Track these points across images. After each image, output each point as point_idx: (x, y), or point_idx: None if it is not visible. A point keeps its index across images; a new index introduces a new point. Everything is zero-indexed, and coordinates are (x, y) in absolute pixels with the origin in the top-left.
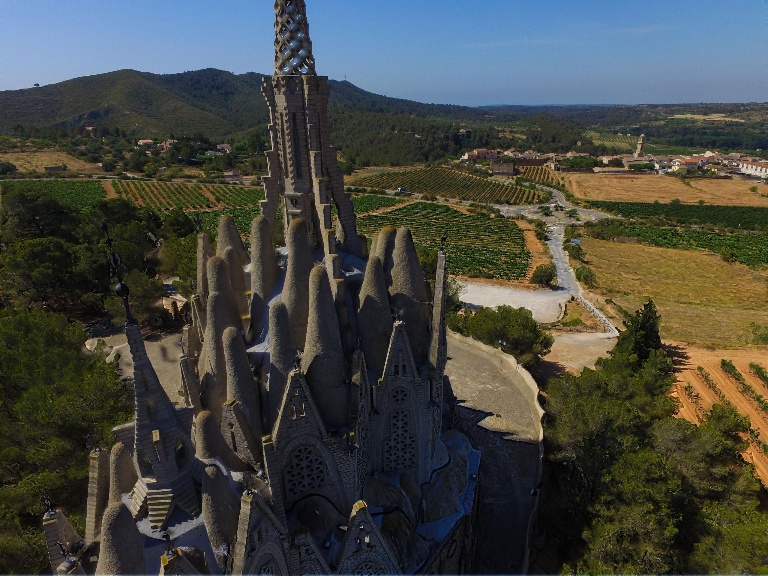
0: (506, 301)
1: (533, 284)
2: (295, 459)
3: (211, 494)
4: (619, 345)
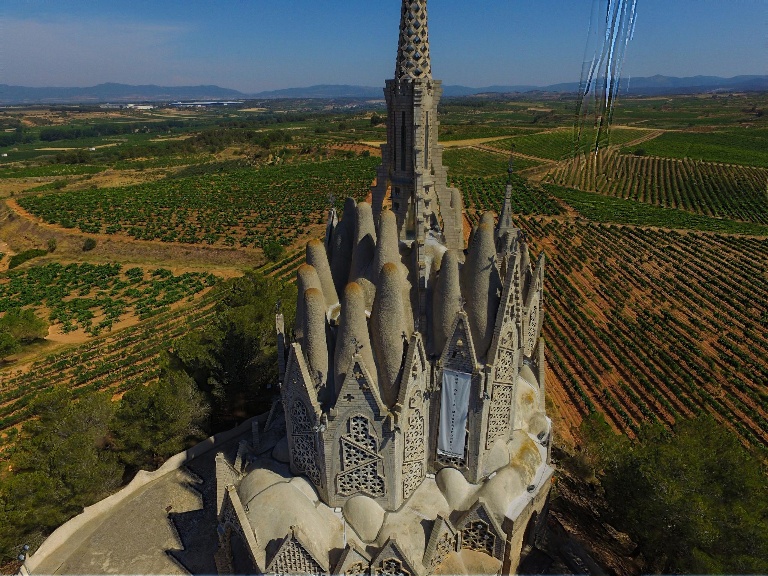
0: None
1: None
2: None
3: None
4: None
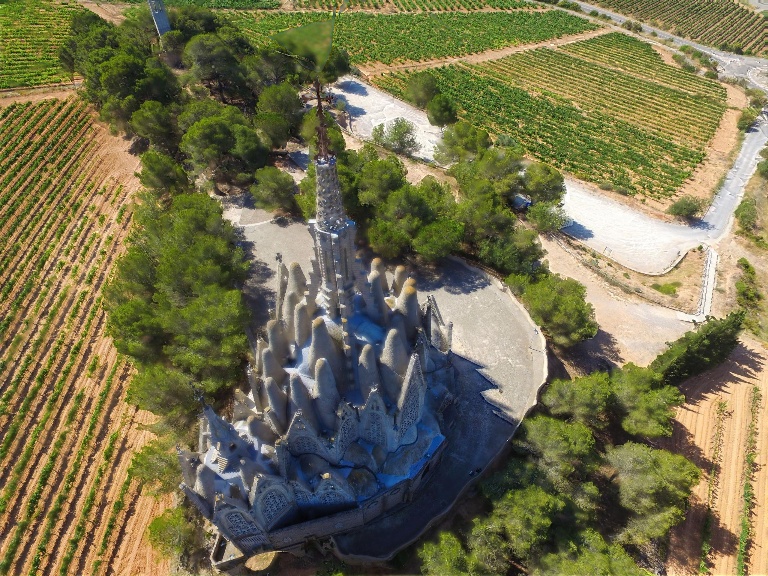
0: (622, 231)
1: (668, 215)
2: (300, 440)
3: (242, 470)
4: (681, 341)
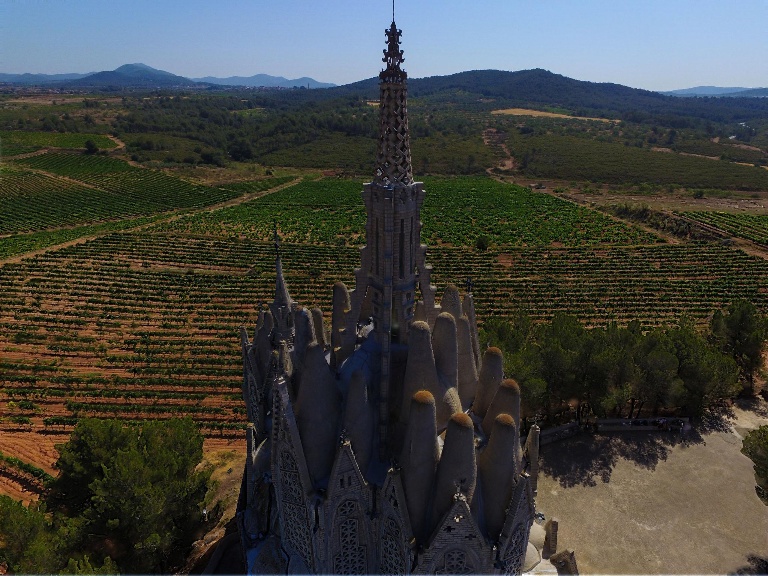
0: None
1: None
2: None
3: None
4: None
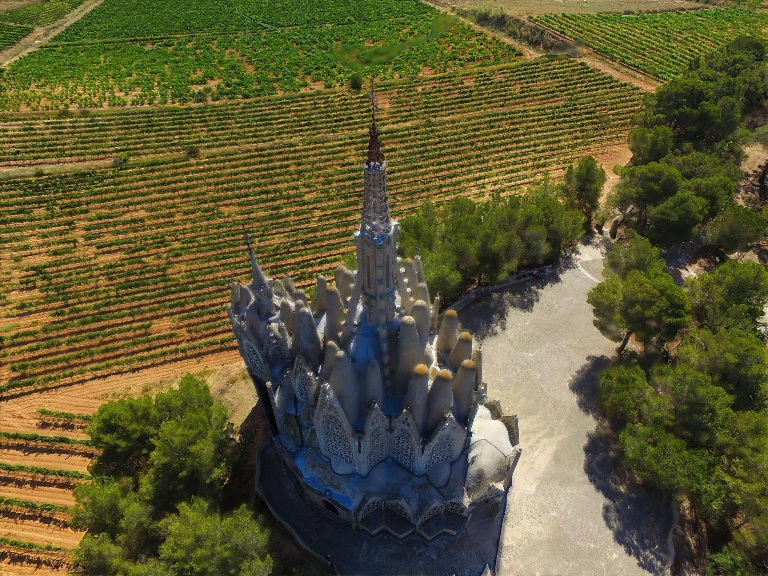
0: None
1: None
2: None
3: None
4: None
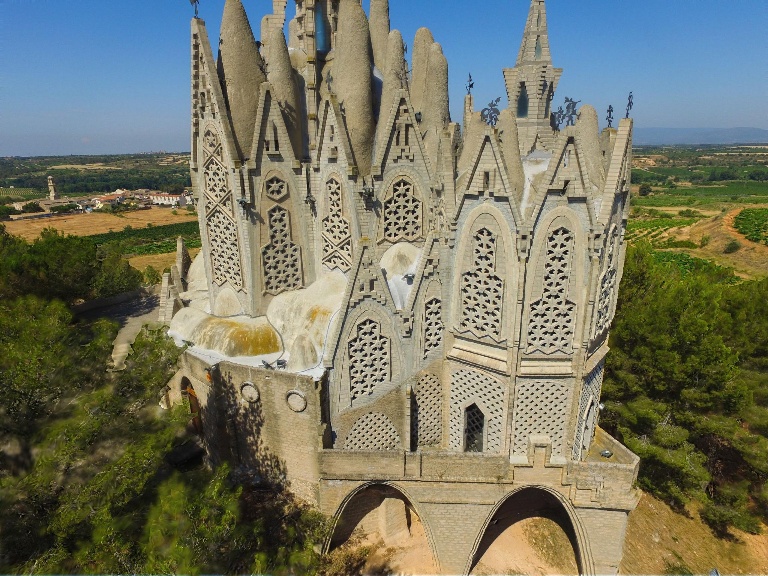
0: None
1: None
2: None
3: None
4: None
